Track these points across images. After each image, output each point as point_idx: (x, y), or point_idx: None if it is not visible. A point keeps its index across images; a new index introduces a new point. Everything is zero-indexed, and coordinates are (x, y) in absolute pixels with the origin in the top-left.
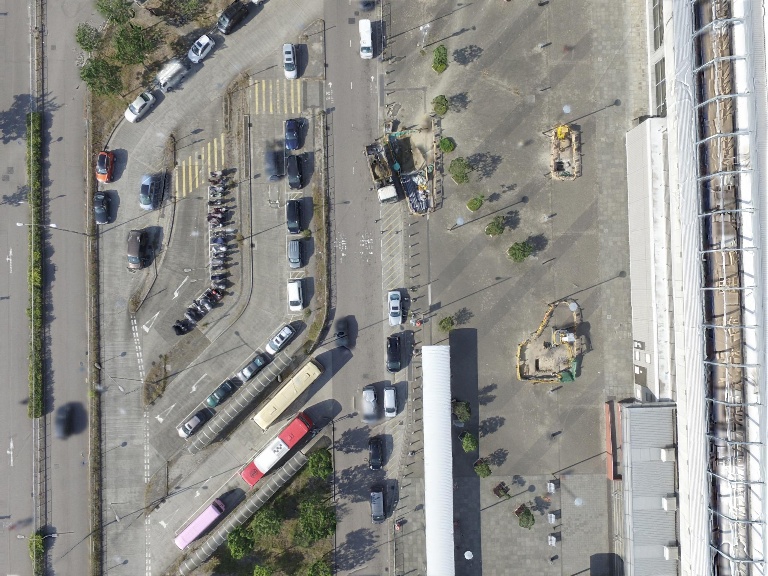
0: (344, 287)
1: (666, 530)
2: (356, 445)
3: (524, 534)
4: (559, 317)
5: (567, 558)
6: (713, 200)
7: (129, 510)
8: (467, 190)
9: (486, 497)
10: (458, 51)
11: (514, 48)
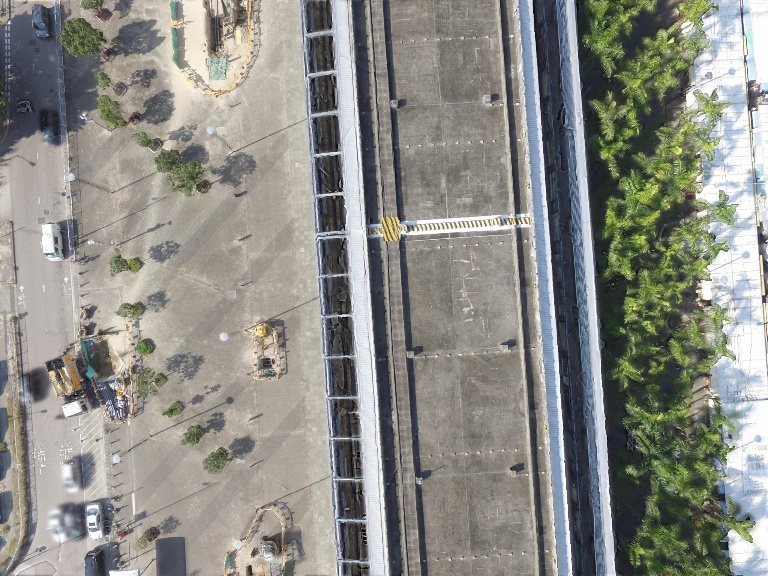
0: (45, 499)
1: None
2: None
3: None
4: (269, 522)
5: None
6: (354, 446)
7: None
8: (169, 393)
9: None
10: (154, 248)
11: (212, 242)
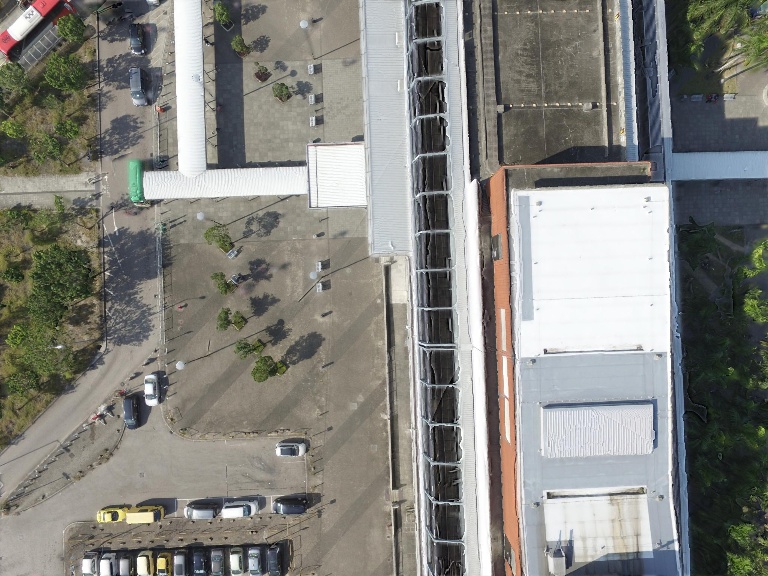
0: None
1: (401, 68)
2: (120, 34)
3: (286, 118)
4: None
5: (329, 141)
6: None
7: None
8: None
9: (249, 82)
10: None
11: None
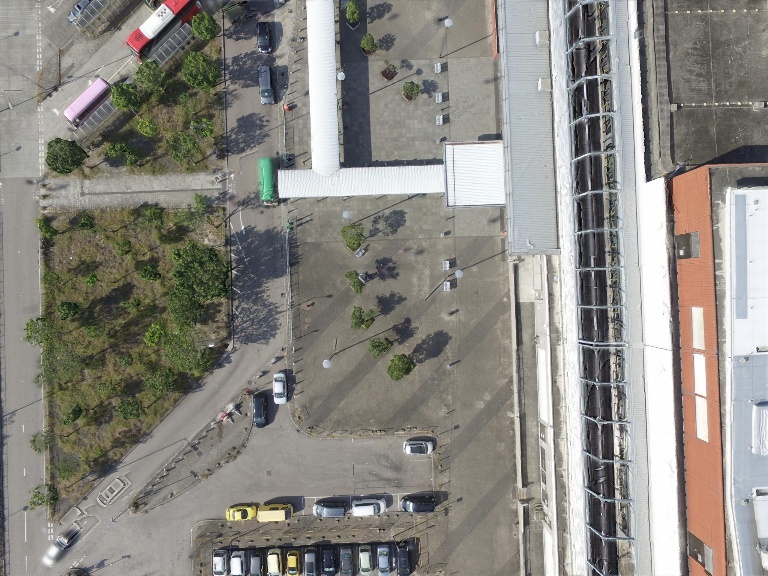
0: None
1: (540, 67)
2: (246, 33)
3: (413, 117)
4: None
5: (455, 139)
6: None
7: (22, 98)
8: None
9: (375, 81)
10: None
11: None
